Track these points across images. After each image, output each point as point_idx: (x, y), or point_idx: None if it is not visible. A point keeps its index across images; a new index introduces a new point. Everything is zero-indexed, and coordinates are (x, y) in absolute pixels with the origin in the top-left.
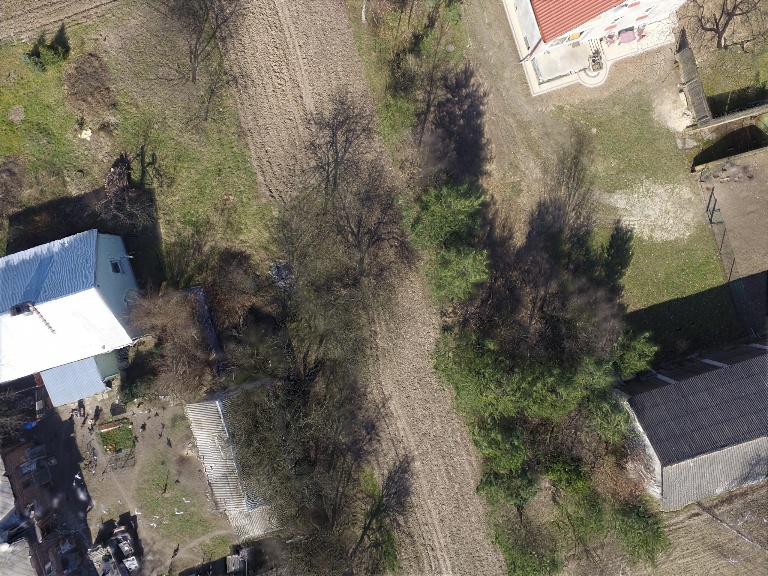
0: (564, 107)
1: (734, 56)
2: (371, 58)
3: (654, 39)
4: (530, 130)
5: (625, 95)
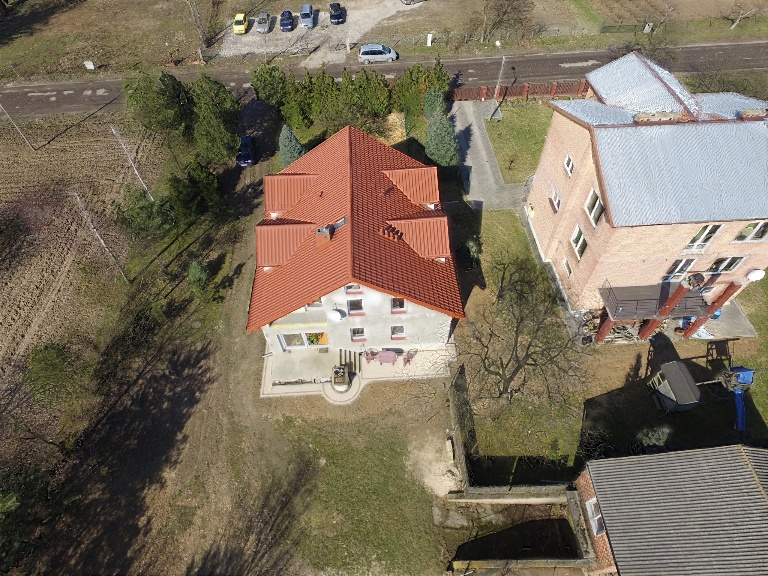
0: (295, 420)
1: (523, 411)
2: (114, 316)
3: (425, 368)
4: (243, 438)
5: (376, 425)
